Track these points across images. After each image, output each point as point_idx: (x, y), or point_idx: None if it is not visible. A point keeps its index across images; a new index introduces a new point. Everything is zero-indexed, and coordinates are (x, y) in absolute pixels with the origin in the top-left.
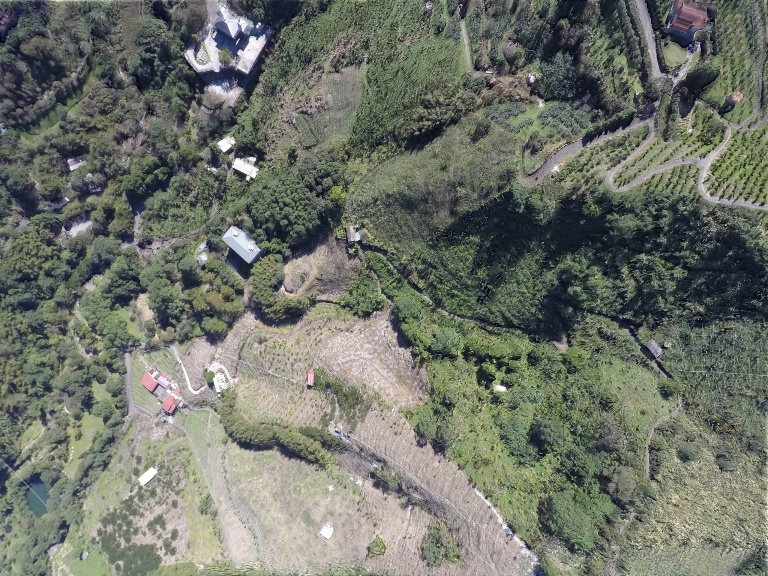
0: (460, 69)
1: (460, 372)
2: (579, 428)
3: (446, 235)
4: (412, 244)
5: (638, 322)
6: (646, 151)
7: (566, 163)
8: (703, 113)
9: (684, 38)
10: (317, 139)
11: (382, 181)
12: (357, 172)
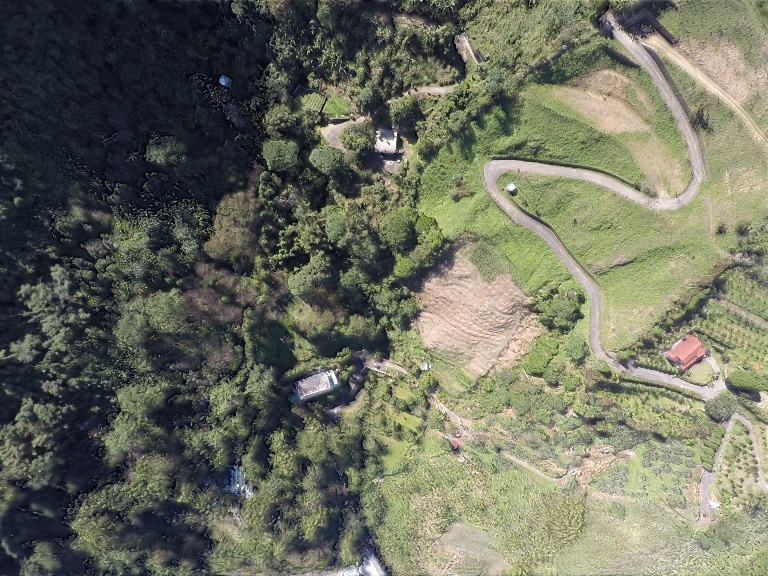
0: (547, 487)
1: None
2: None
3: (663, 564)
4: (635, 573)
5: None
6: (765, 445)
7: (717, 498)
8: None
9: None
10: (479, 569)
11: (572, 570)
12: (542, 573)
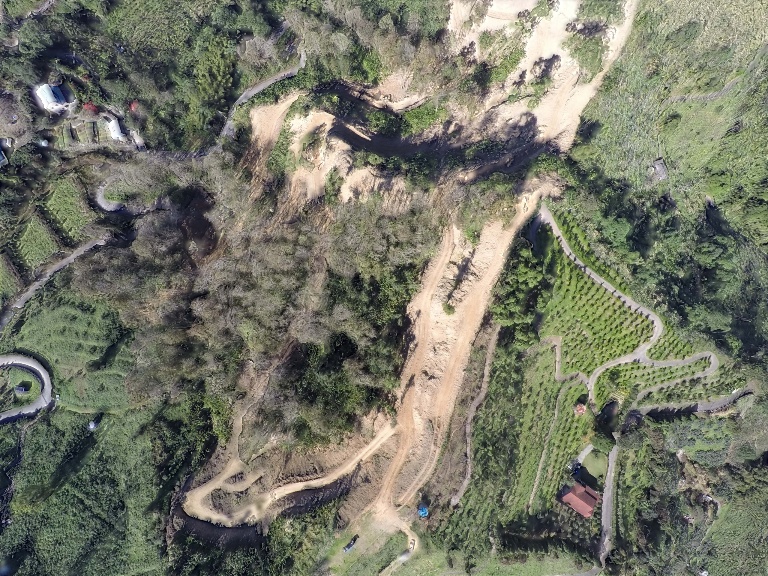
0: None
1: None
2: (764, 110)
3: None
4: None
5: (668, 203)
6: None
7: None
8: (601, 400)
9: (582, 476)
10: None
11: None
12: None
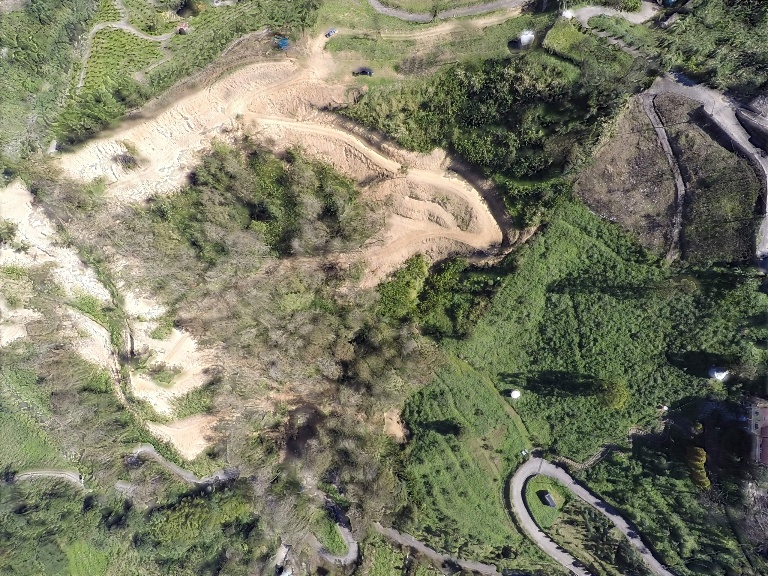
0: None
1: (26, 25)
2: None
3: None
4: None
5: None
6: None
7: None
8: None
9: None
10: None
11: None
12: None
